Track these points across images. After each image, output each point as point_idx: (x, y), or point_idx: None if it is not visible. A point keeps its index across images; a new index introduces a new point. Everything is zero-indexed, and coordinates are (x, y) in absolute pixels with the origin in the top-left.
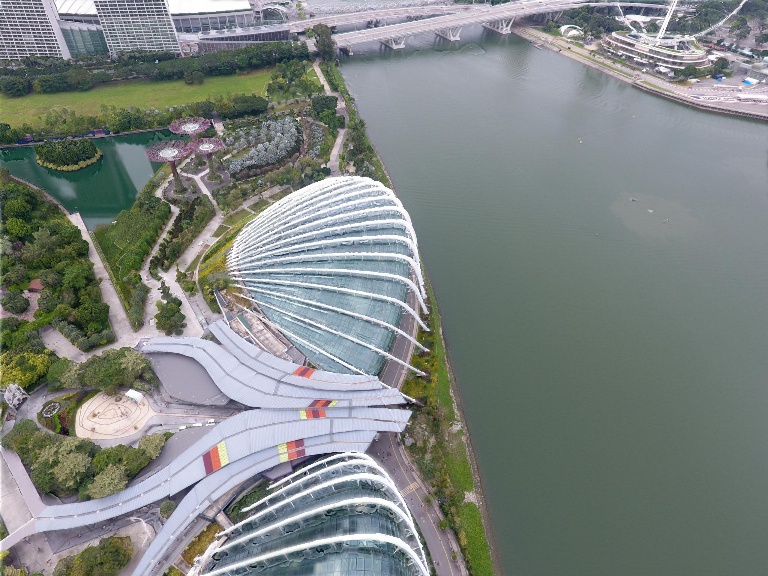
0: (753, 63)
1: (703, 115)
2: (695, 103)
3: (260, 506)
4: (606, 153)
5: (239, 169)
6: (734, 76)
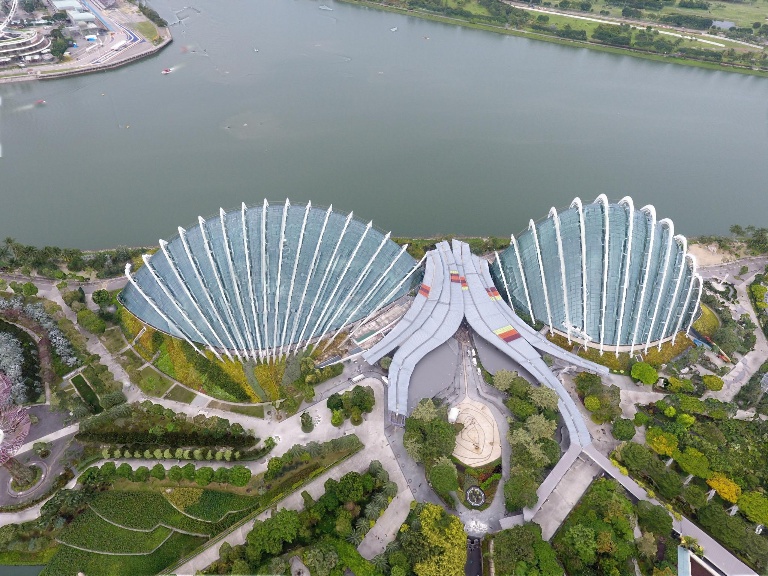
0: (65, 26)
1: (119, 71)
2: (106, 66)
3: None
4: (154, 121)
5: (21, 387)
6: (75, 40)
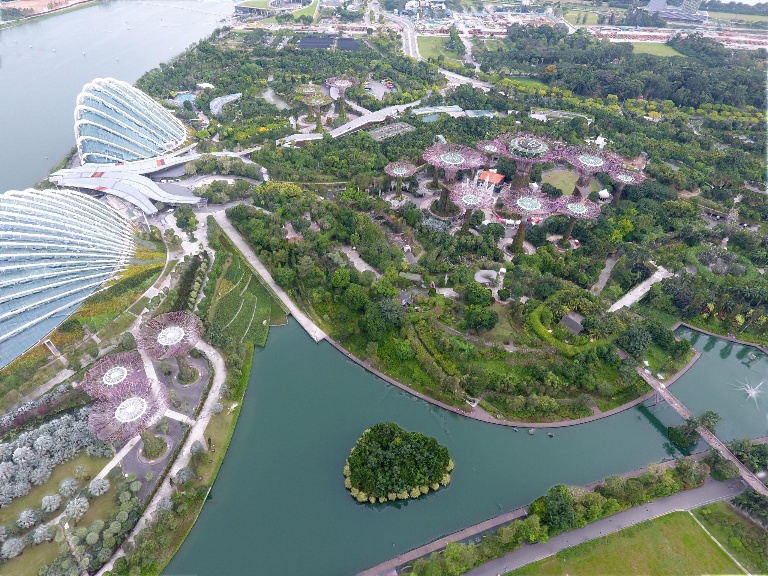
0: None
1: None
2: None
3: None
4: None
5: None
6: None
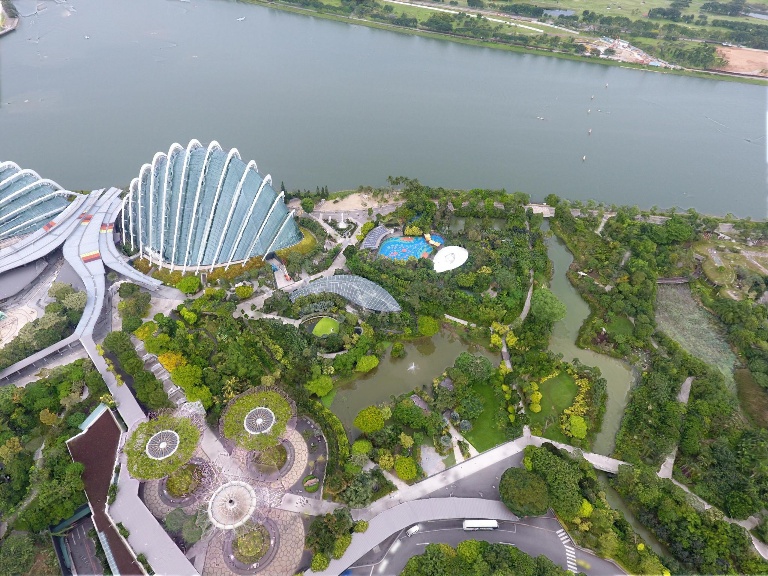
0: None
1: None
2: None
3: (134, 240)
4: None
5: None
6: None
